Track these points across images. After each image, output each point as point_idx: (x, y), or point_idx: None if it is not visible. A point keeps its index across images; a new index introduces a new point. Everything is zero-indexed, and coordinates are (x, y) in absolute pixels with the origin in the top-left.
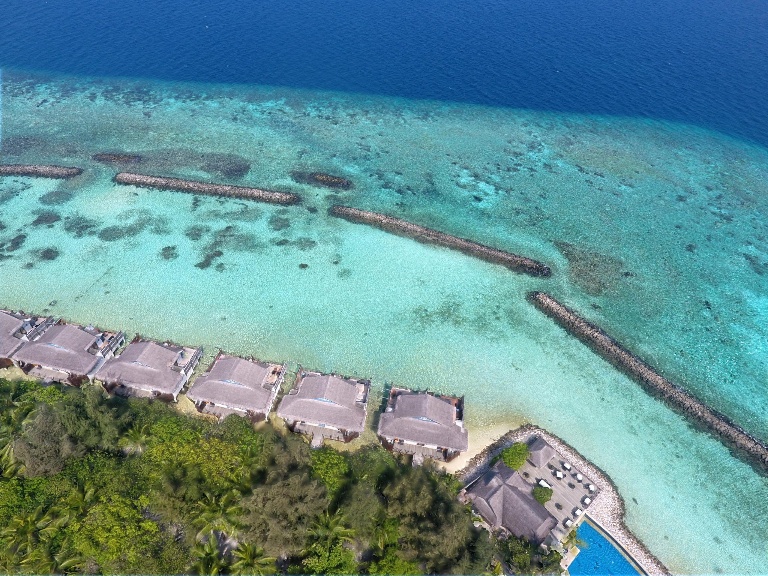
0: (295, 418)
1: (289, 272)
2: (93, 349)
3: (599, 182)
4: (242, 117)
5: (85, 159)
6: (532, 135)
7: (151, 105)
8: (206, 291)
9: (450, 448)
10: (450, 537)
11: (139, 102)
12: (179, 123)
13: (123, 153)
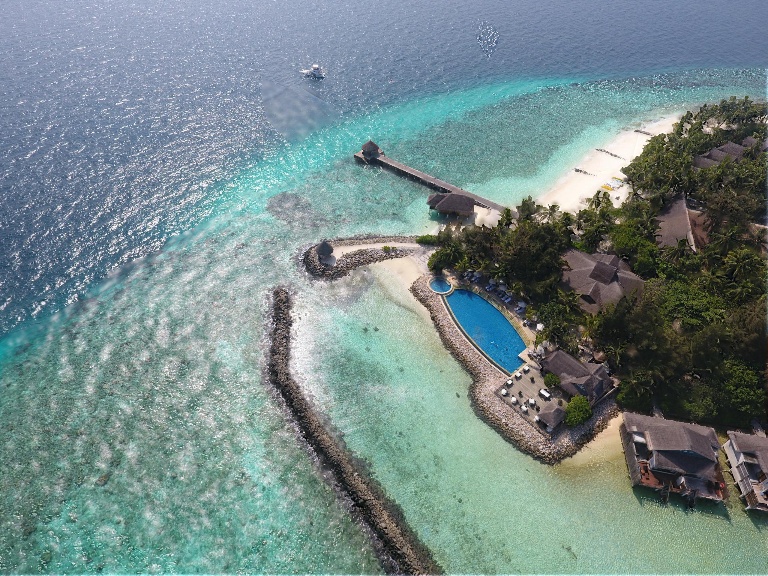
0: None
1: None
2: None
3: None
4: None
5: None
6: None
7: None
8: None
9: None
10: None
11: None
12: None
13: None
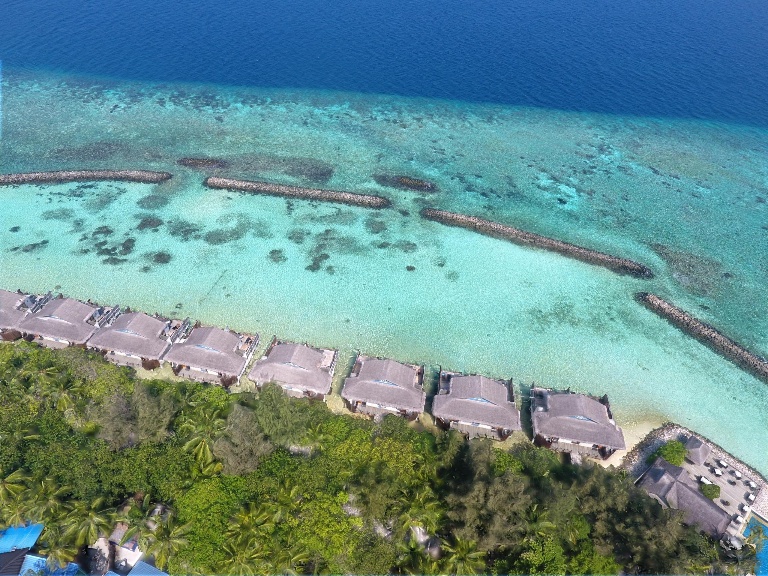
0: (452, 417)
1: (398, 274)
2: (239, 351)
3: (676, 184)
4: (312, 121)
5: (171, 164)
6: (599, 138)
7: (220, 110)
8: (323, 293)
9: (609, 446)
10: (666, 531)
11: (208, 107)
12: (252, 128)
13: (206, 158)
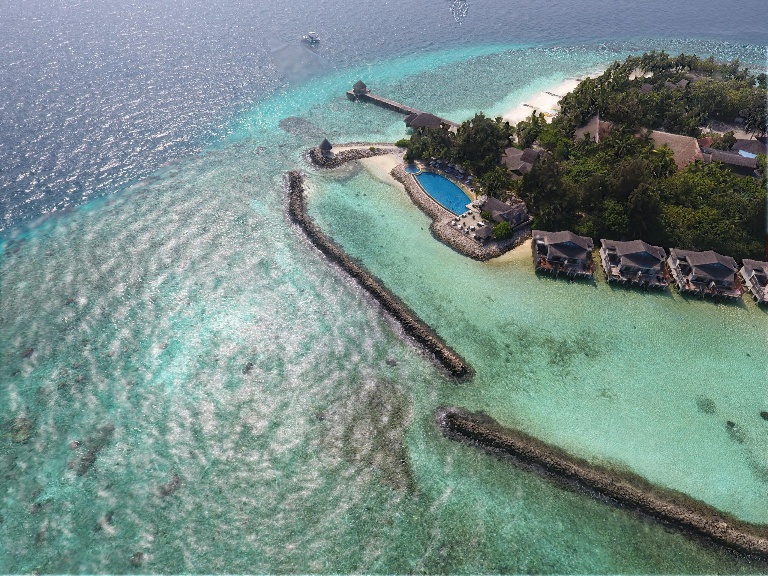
0: None
1: None
2: None
3: None
4: None
5: None
6: None
7: None
8: None
9: None
10: None
11: None
12: None
13: None
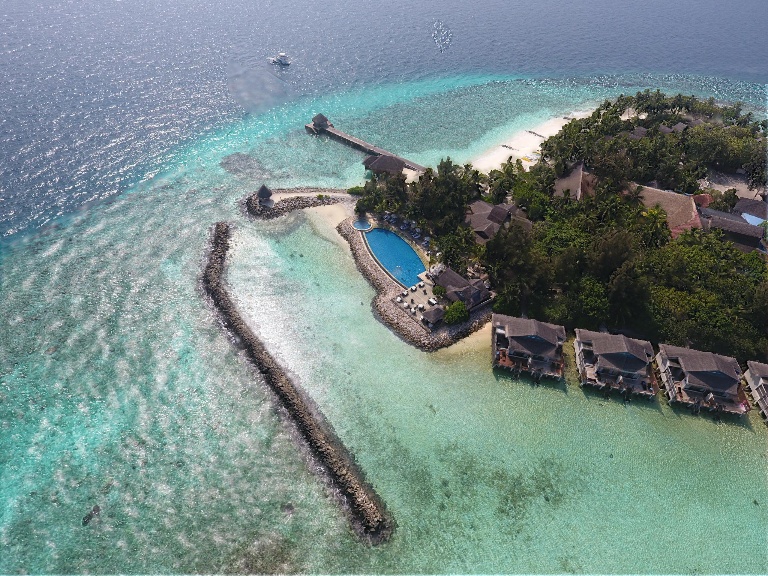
0: None
1: None
2: None
3: None
4: None
5: None
6: None
7: None
8: None
9: None
10: None
11: None
12: None
13: None
